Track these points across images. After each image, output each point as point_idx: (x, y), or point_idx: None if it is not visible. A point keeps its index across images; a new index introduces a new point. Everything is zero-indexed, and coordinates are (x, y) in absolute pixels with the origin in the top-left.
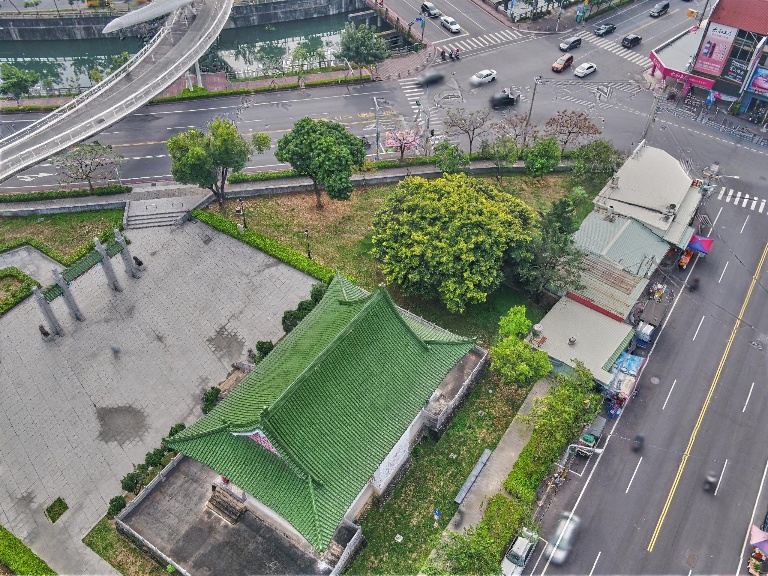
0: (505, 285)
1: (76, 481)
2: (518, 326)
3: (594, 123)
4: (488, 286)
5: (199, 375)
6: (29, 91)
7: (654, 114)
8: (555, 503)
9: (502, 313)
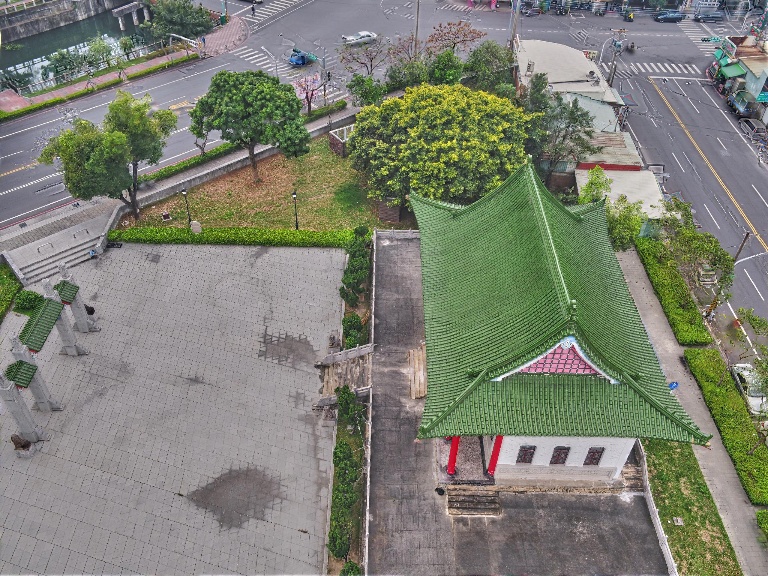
0: None
1: None
2: None
3: (474, 28)
4: None
5: (286, 395)
6: None
7: (520, 6)
8: None
9: None
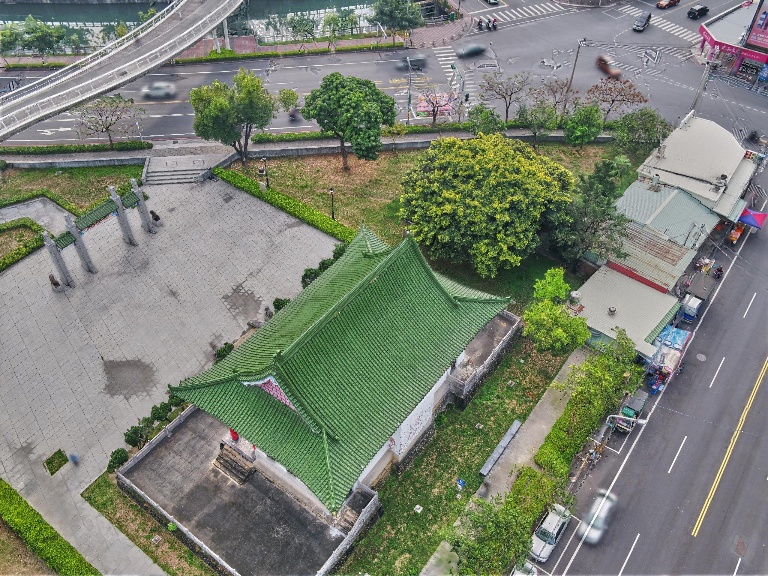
0: (540, 254)
1: (78, 434)
2: (555, 289)
3: (640, 91)
4: (523, 250)
5: (212, 332)
6: (54, 47)
7: (705, 82)
8: (590, 480)
9: (536, 282)
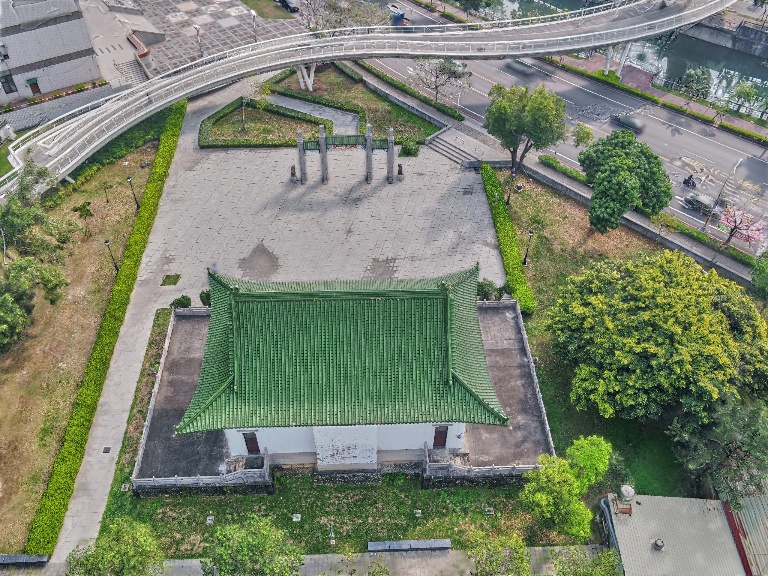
0: None
1: (198, 274)
2: (585, 459)
3: None
4: (629, 409)
5: (338, 276)
6: (480, 11)
7: None
8: None
9: (639, 457)
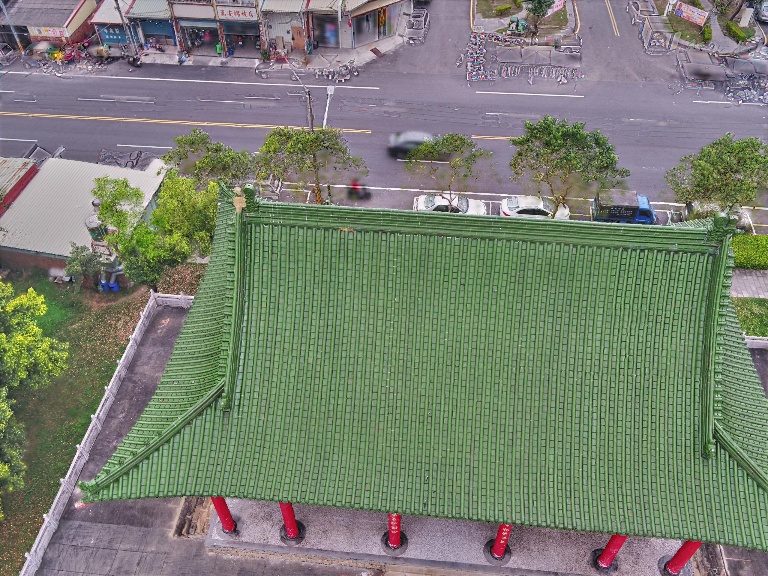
0: None
1: None
2: None
3: None
4: None
5: None
6: None
7: None
8: (362, 203)
9: None
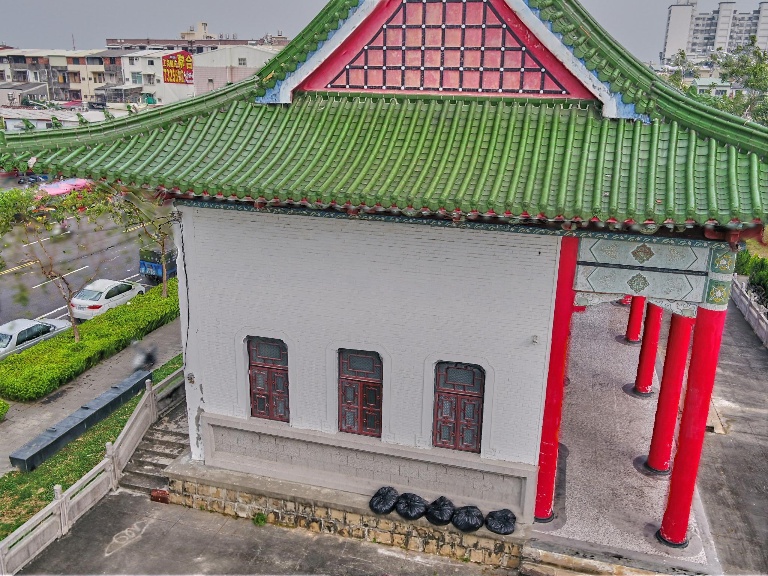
0: None
1: None
2: None
3: None
4: None
5: None
6: None
7: None
8: None
9: None
